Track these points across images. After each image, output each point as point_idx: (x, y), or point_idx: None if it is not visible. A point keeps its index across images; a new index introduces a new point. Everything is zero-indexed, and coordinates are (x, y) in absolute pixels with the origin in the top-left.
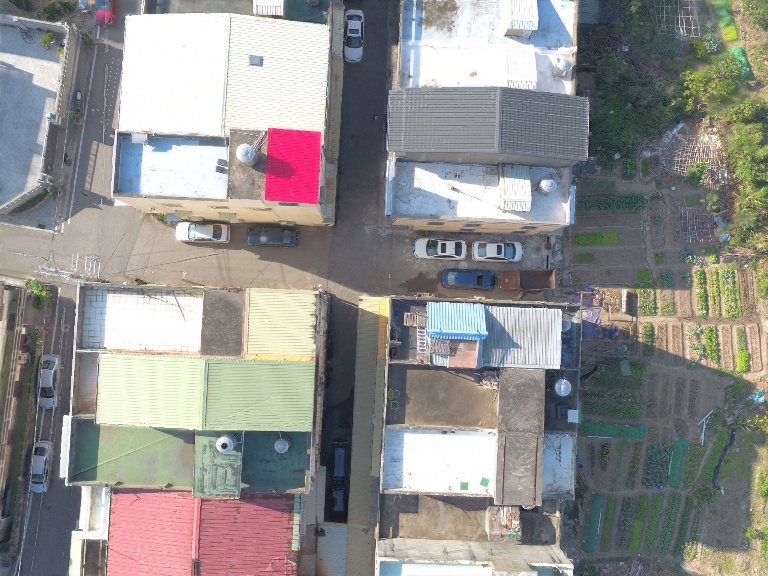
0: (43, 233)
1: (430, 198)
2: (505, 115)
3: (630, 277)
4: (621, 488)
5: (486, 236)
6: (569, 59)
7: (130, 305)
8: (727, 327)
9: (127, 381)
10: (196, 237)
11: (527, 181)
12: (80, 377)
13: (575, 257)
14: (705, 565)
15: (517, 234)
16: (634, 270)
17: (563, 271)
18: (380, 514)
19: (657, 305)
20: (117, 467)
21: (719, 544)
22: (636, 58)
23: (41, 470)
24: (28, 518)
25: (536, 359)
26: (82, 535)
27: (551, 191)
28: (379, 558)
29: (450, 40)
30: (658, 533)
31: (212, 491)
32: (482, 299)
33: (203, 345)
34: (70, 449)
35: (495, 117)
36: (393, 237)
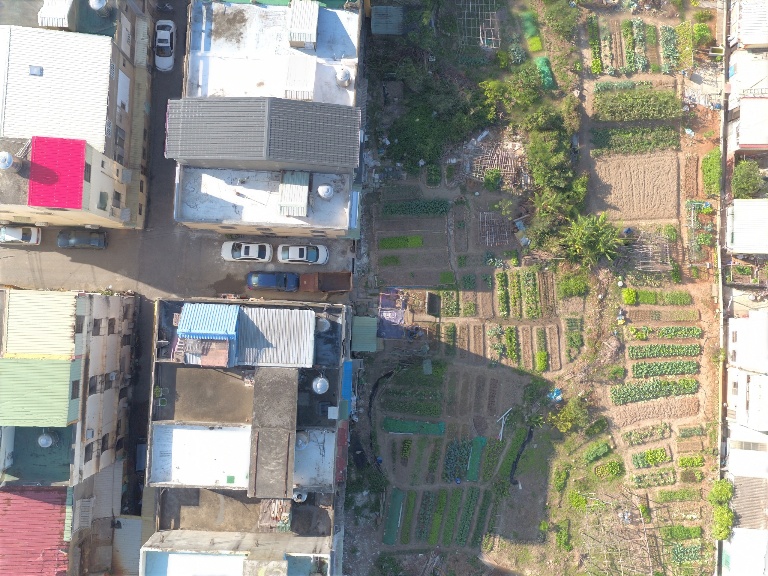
0: None
1: (216, 203)
2: (274, 124)
3: (434, 279)
4: (422, 483)
5: (293, 239)
6: (352, 70)
7: None
8: (527, 328)
9: None
10: (5, 239)
11: (305, 187)
12: None
13: (380, 260)
14: (502, 557)
15: (322, 237)
16: (438, 272)
17: (369, 273)
18: (162, 507)
19: (460, 306)
20: None
21: (515, 537)
22: (443, 68)
23: None
24: None
25: (289, 358)
26: None
27: (329, 197)
28: (142, 548)
29: (238, 51)
30: (457, 526)
31: None
32: (254, 300)
33: None
34: None
35: (264, 126)
36: (202, 240)
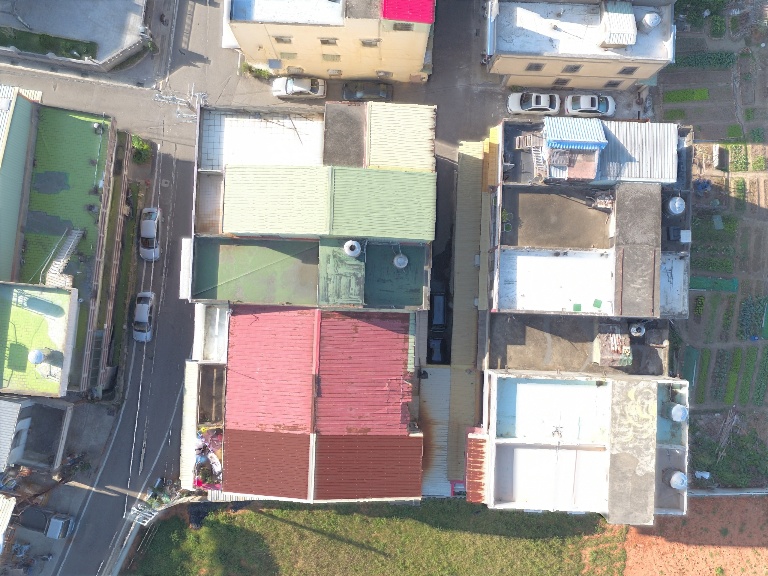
0: (142, 91)
1: (533, 37)
2: None
3: (721, 133)
4: (715, 340)
5: (578, 92)
6: None
7: (247, 129)
8: None
9: (253, 190)
10: (294, 90)
11: (631, 15)
12: (200, 199)
13: (666, 113)
14: None
15: (609, 89)
16: (725, 126)
17: None
18: None
19: (748, 160)
20: (237, 287)
21: None
22: None
23: (146, 318)
24: (131, 368)
25: (653, 172)
26: (198, 361)
27: (655, 26)
28: (496, 374)
29: None
30: (753, 385)
31: (336, 300)
32: None
33: (326, 158)
34: (193, 266)
35: None
36: (486, 93)
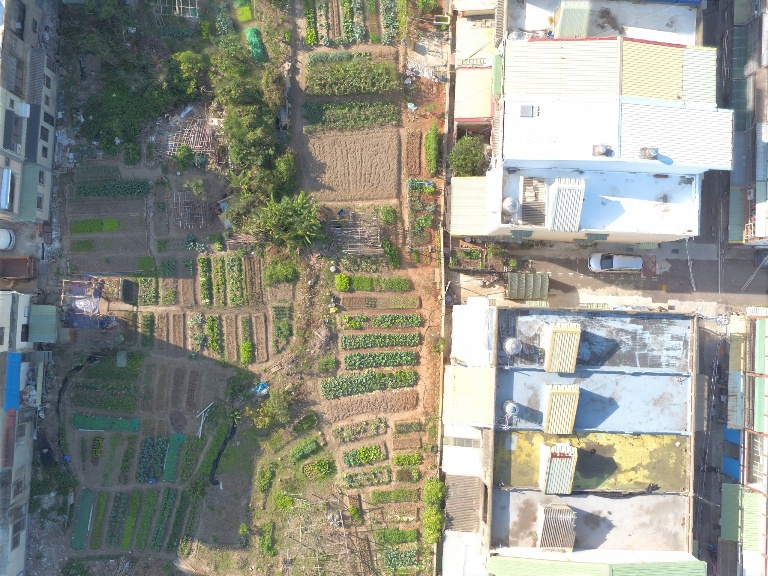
0: None
1: None
2: None
3: (131, 265)
4: (114, 483)
5: None
6: None
7: None
8: (232, 316)
9: None
10: None
11: None
12: None
13: (73, 245)
14: (200, 562)
15: (5, 221)
16: (135, 258)
17: (61, 259)
18: None
19: (159, 294)
20: None
21: (215, 541)
22: (144, 40)
23: None
24: None
25: None
26: None
27: None
28: None
29: None
30: (152, 529)
31: None
32: None
33: None
34: None
35: None
36: None
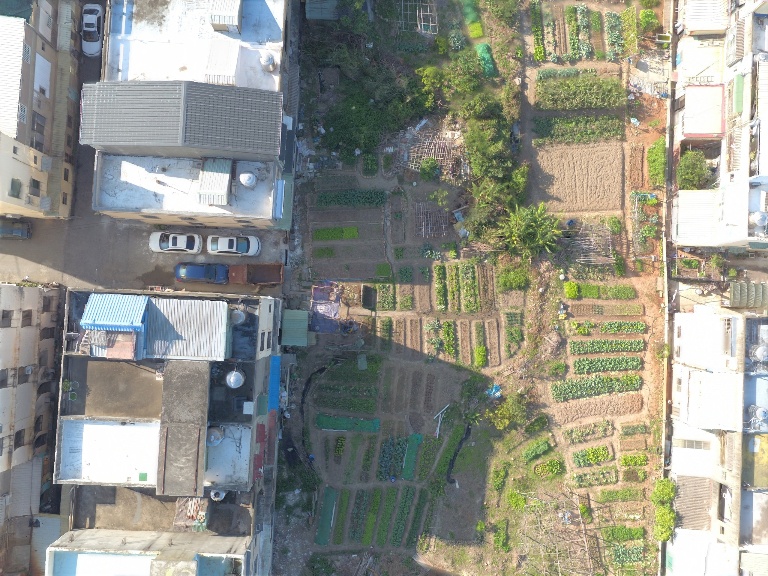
0: None
1: (136, 191)
2: (190, 109)
3: (369, 272)
4: (355, 481)
5: (224, 230)
6: (277, 54)
7: None
8: (466, 322)
9: None
10: None
11: (226, 175)
12: None
13: (314, 252)
14: (438, 558)
15: (253, 228)
16: (374, 265)
17: (302, 265)
18: (77, 505)
19: (396, 300)
20: None
21: (452, 537)
22: (381, 54)
23: None
24: None
25: (200, 351)
26: None
27: (251, 185)
28: (48, 548)
29: (160, 34)
30: (392, 526)
31: None
32: (170, 292)
33: None
34: None
35: (179, 111)
36: (130, 230)
